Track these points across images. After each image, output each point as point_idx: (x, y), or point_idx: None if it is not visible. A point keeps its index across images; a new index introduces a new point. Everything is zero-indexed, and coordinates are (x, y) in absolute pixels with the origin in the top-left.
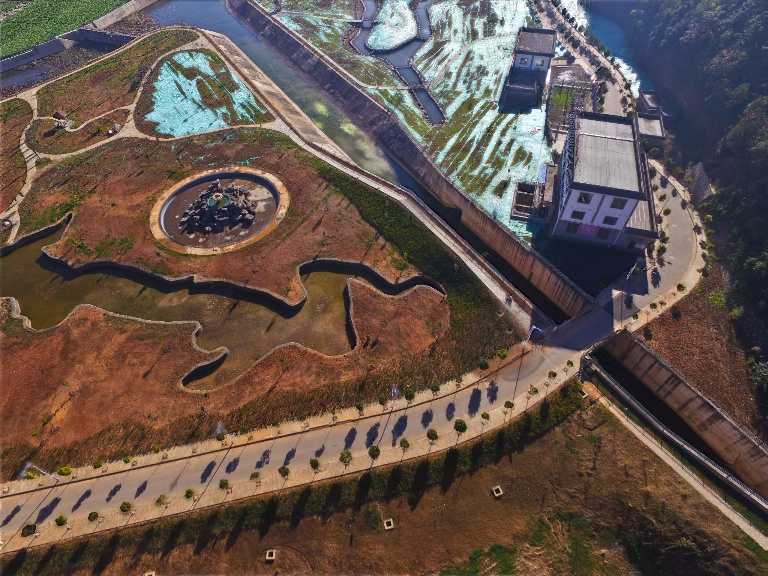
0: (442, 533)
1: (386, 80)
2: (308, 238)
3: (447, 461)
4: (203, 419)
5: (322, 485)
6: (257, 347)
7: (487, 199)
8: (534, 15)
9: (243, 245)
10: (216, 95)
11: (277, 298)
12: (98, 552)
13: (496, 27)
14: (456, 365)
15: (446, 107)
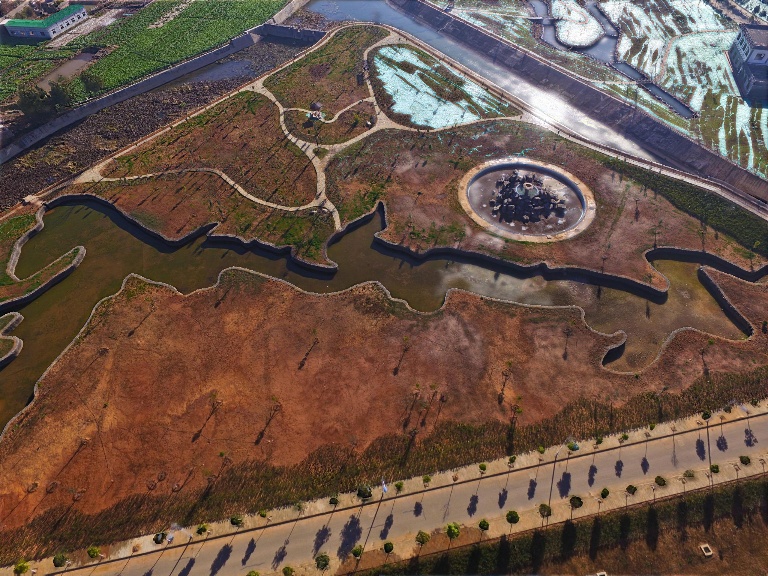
0: None
1: (607, 75)
2: (636, 227)
3: None
4: (658, 399)
5: None
6: (649, 331)
7: None
8: (720, 13)
9: (574, 233)
10: (447, 88)
11: (643, 284)
12: (644, 524)
13: (688, 24)
14: None
15: (688, 102)
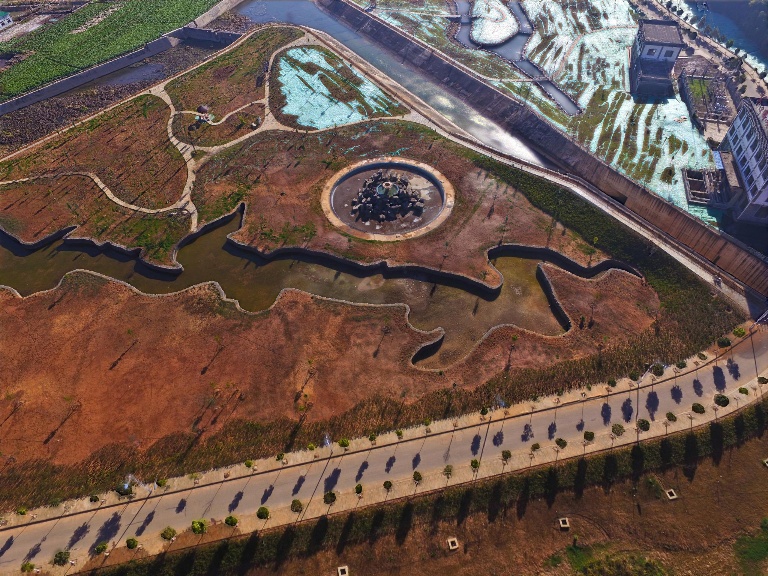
0: (727, 503)
1: (506, 73)
2: (486, 224)
3: (713, 434)
4: (451, 395)
5: (596, 457)
6: (470, 328)
7: (658, 186)
8: (636, 8)
9: (423, 231)
10: (343, 89)
11: (476, 282)
12: (397, 519)
13: (601, 20)
14: (687, 344)
15: (578, 98)
